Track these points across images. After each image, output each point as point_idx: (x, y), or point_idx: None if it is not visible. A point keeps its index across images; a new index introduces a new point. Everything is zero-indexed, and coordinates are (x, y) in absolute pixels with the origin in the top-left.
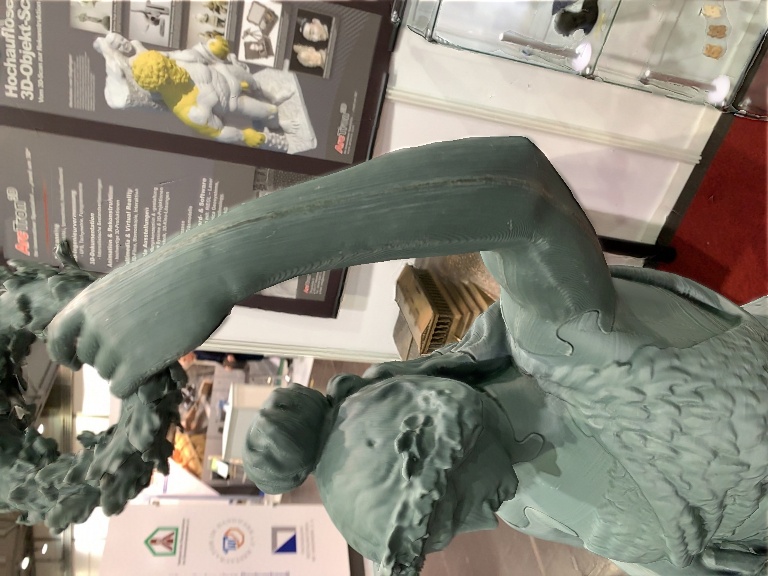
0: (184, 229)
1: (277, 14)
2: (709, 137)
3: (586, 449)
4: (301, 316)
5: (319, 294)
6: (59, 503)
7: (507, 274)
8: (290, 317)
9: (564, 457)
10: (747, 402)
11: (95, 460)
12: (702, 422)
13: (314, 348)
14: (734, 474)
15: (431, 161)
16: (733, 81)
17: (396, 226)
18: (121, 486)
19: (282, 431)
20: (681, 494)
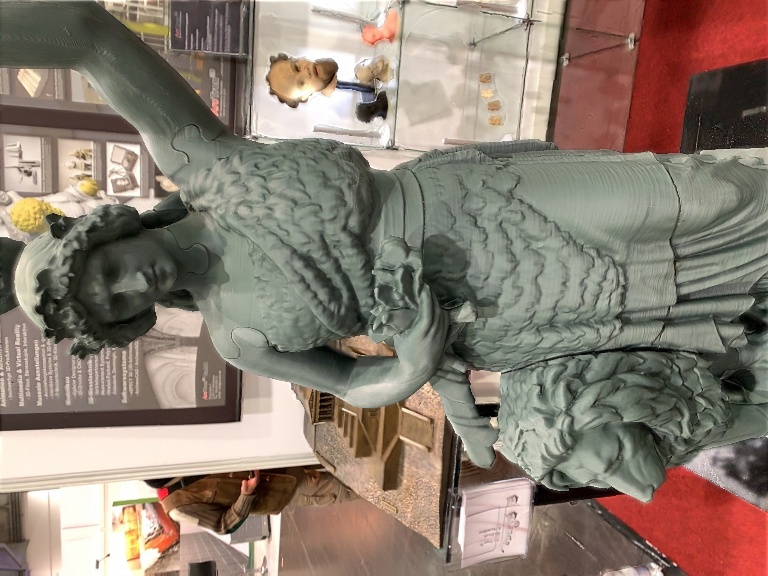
0: None
1: (137, 153)
2: None
3: (233, 244)
4: (205, 425)
5: (219, 399)
6: None
7: (105, 91)
8: (194, 428)
9: (227, 262)
10: (307, 164)
11: None
12: (279, 181)
13: (227, 461)
14: (313, 215)
15: None
16: (513, 136)
17: None
18: None
19: None
20: (286, 243)
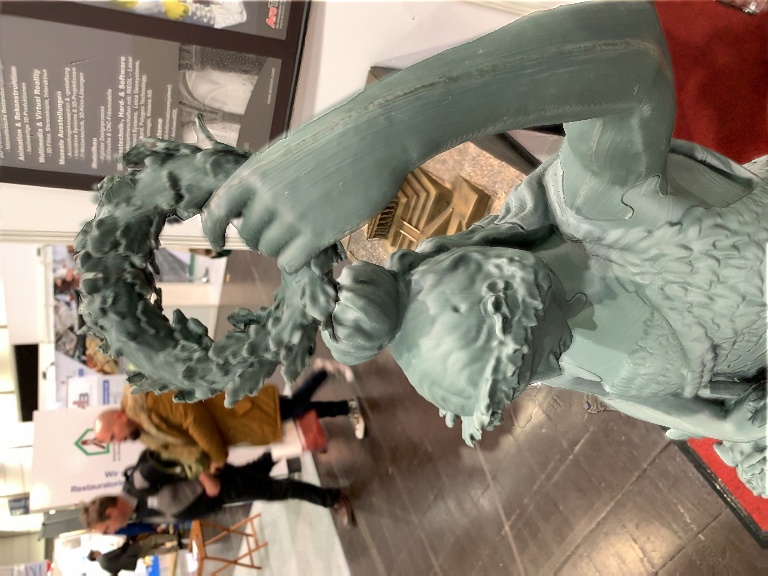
0: (104, 115)
1: None
2: None
3: (625, 304)
4: None
5: None
6: (238, 376)
7: (601, 141)
8: None
9: (601, 313)
10: None
11: (273, 333)
12: (738, 271)
13: None
14: (756, 314)
15: (577, 24)
16: None
17: (553, 91)
18: (298, 356)
19: (371, 304)
20: (709, 335)
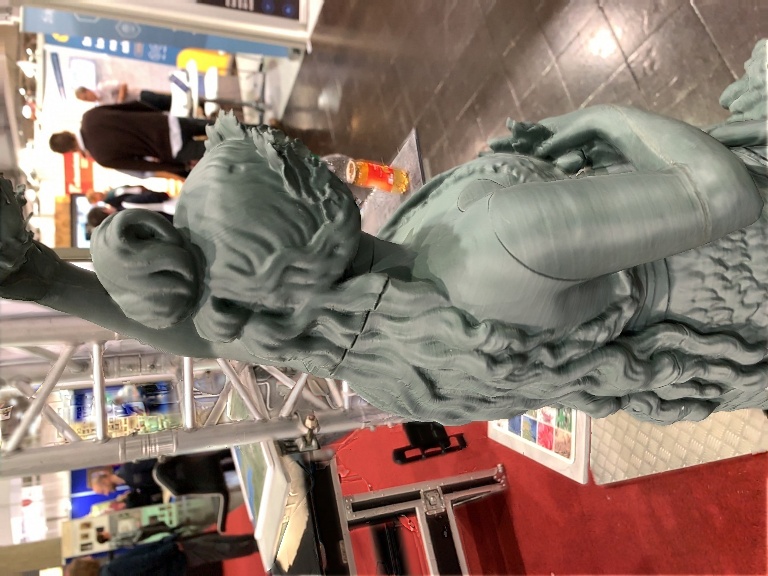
0: None
1: None
2: None
3: None
4: None
5: None
6: None
7: None
8: None
9: None
10: None
11: None
12: None
13: None
14: None
15: None
16: None
17: None
18: None
19: None
20: None
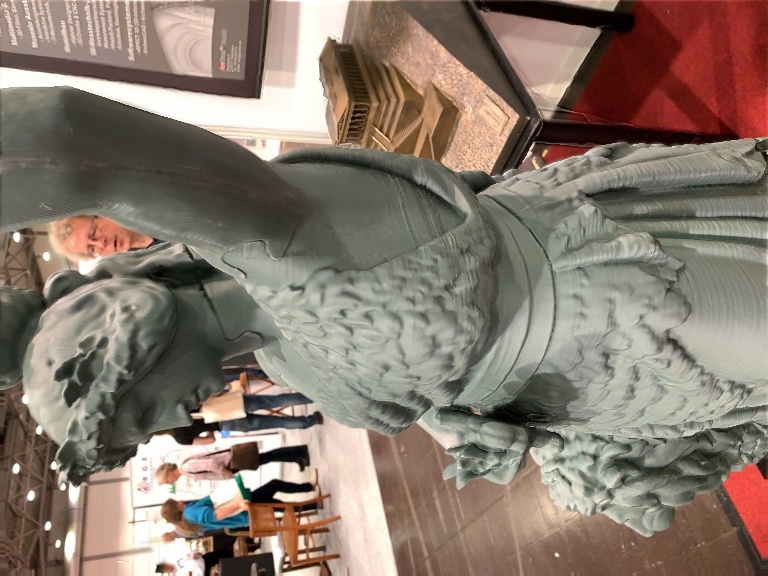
0: None
1: None
2: None
3: None
4: (221, 96)
5: (237, 72)
6: None
7: None
8: (209, 98)
9: (285, 348)
10: (415, 325)
11: None
12: (370, 343)
13: (243, 129)
14: (407, 383)
15: None
16: None
17: None
18: None
19: None
20: (365, 395)
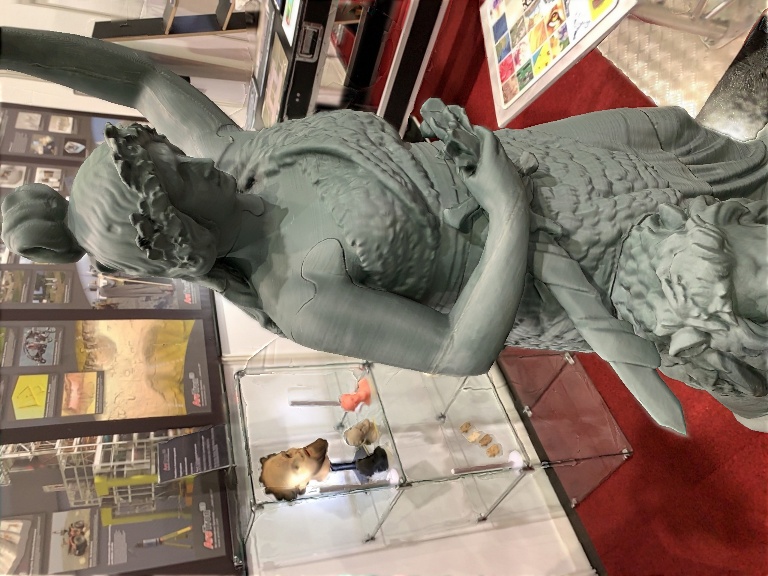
0: None
1: None
2: (583, 550)
3: (285, 180)
4: None
5: None
6: None
7: (161, 100)
8: None
9: (282, 201)
10: None
11: None
12: None
13: None
14: None
15: None
16: (517, 448)
17: None
18: None
19: None
20: None
